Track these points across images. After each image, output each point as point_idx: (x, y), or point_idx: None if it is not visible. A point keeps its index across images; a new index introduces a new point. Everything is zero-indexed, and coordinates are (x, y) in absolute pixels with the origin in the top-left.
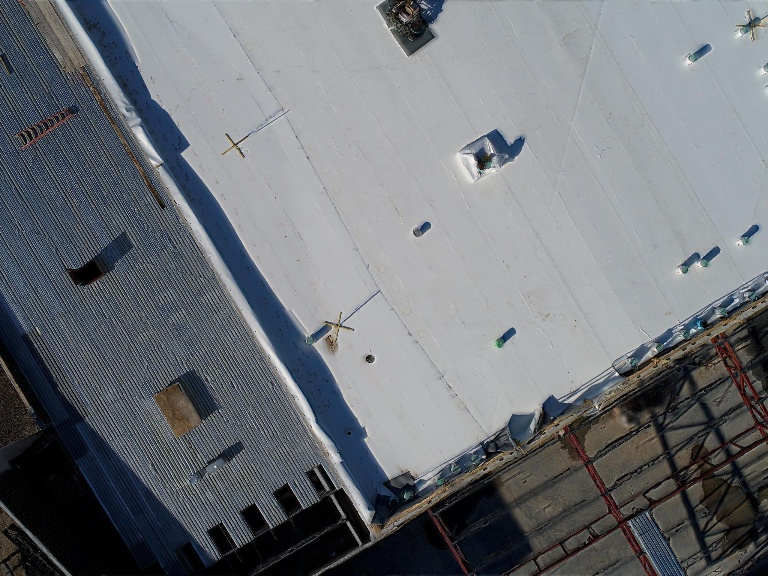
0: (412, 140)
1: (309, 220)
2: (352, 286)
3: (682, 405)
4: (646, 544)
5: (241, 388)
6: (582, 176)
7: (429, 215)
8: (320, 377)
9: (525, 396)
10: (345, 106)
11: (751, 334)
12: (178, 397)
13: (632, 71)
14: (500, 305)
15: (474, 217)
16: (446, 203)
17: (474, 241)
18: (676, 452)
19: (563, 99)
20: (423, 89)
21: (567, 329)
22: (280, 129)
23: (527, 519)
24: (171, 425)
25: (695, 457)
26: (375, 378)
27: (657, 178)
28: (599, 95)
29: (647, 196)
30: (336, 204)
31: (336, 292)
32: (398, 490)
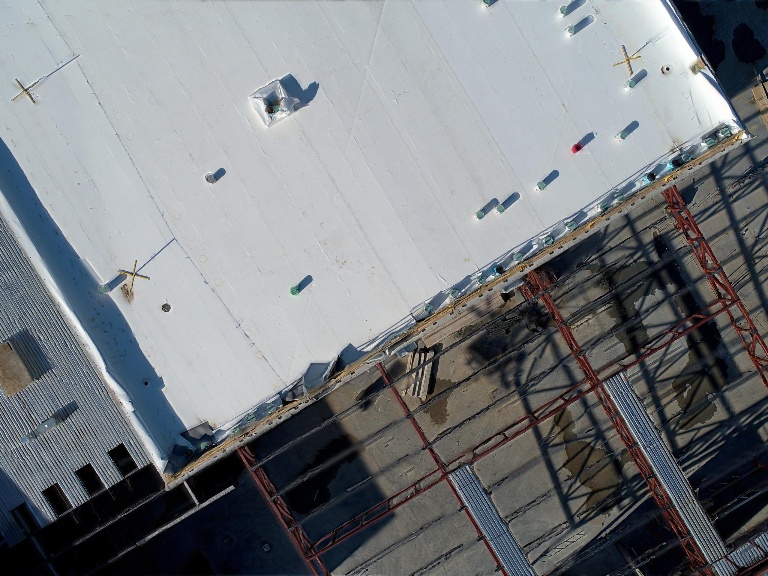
0: (205, 85)
1: (102, 167)
2: (147, 234)
3: (545, 368)
4: (467, 498)
5: (74, 347)
6: (378, 121)
7: (223, 161)
8: (116, 326)
9: (323, 344)
10: (137, 50)
11: (613, 296)
12: (8, 356)
13: (429, 14)
14: (297, 252)
15: (269, 163)
16: (240, 149)
17: (269, 187)
18: (539, 415)
19: (358, 42)
20: (215, 33)
21: (364, 276)
22: (71, 74)
23: (389, 483)
24: (1, 384)
25: (558, 420)
26: (171, 327)
27: (455, 123)
28: (395, 38)
29: (445, 141)
30: (129, 150)
31: (131, 240)
32: (197, 440)
